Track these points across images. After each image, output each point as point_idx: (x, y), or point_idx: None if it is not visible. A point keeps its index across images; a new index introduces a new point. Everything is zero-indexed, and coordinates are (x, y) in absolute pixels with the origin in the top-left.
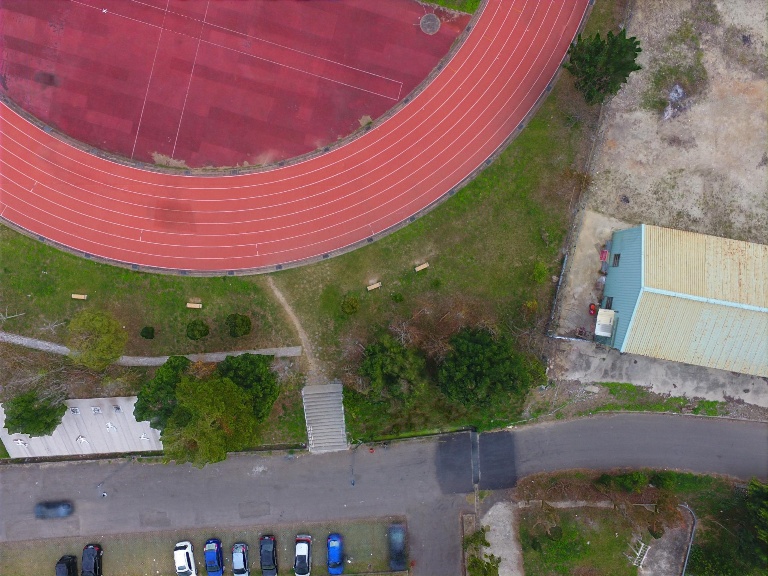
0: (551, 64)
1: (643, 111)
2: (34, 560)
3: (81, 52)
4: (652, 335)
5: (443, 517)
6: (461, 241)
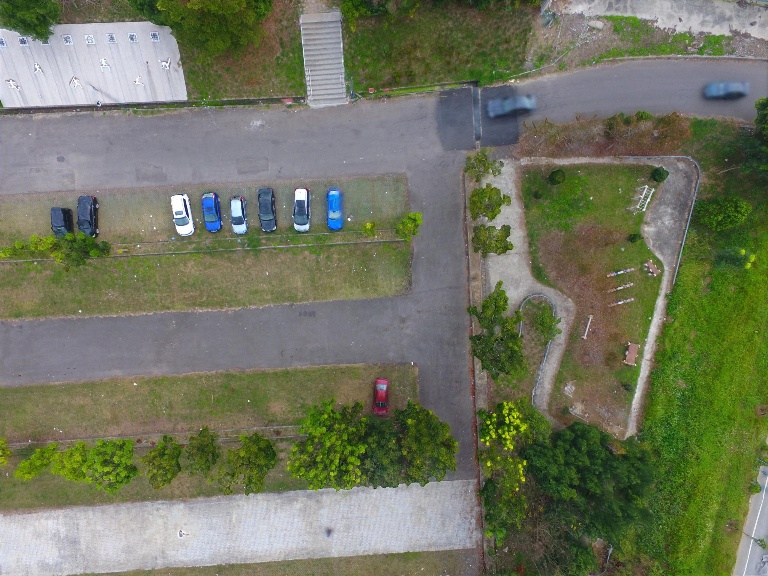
0: None
1: None
2: (29, 214)
3: None
4: None
5: (444, 174)
6: None
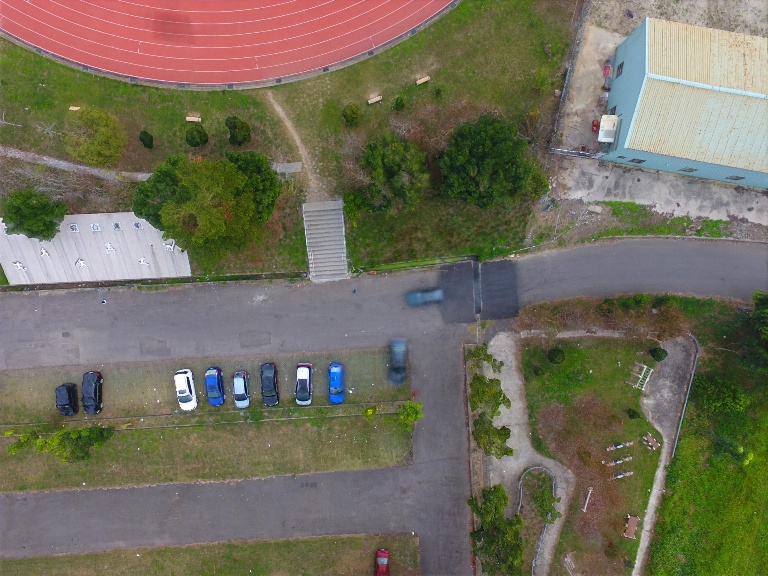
0: None
1: None
2: (34, 389)
3: None
4: (656, 128)
5: (445, 347)
6: (463, 54)
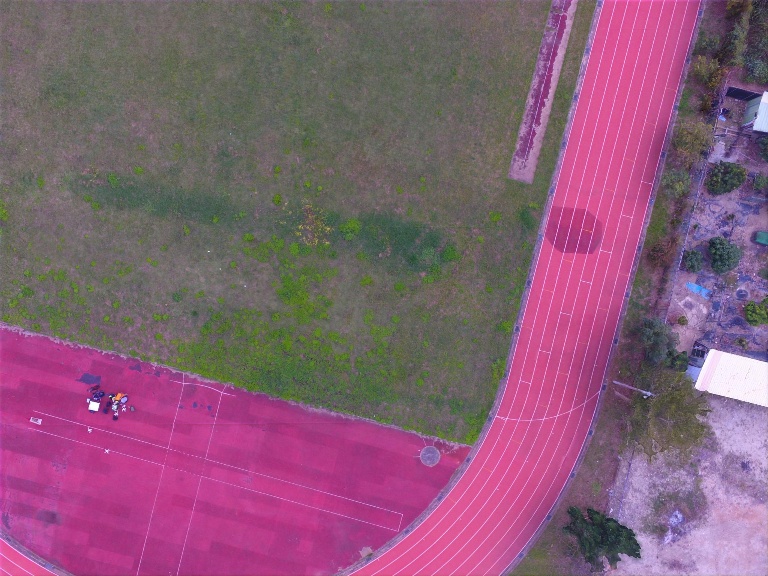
0: (551, 494)
1: (643, 536)
2: None
3: (83, 490)
4: None
5: None
6: None
